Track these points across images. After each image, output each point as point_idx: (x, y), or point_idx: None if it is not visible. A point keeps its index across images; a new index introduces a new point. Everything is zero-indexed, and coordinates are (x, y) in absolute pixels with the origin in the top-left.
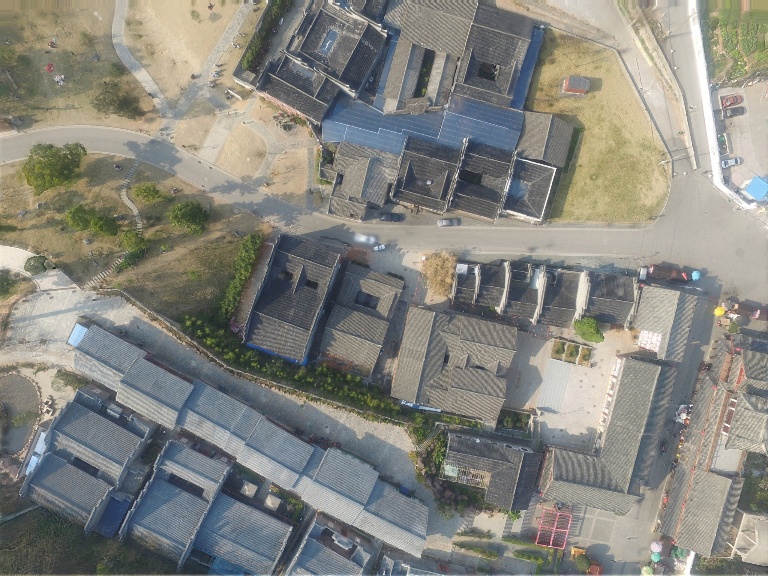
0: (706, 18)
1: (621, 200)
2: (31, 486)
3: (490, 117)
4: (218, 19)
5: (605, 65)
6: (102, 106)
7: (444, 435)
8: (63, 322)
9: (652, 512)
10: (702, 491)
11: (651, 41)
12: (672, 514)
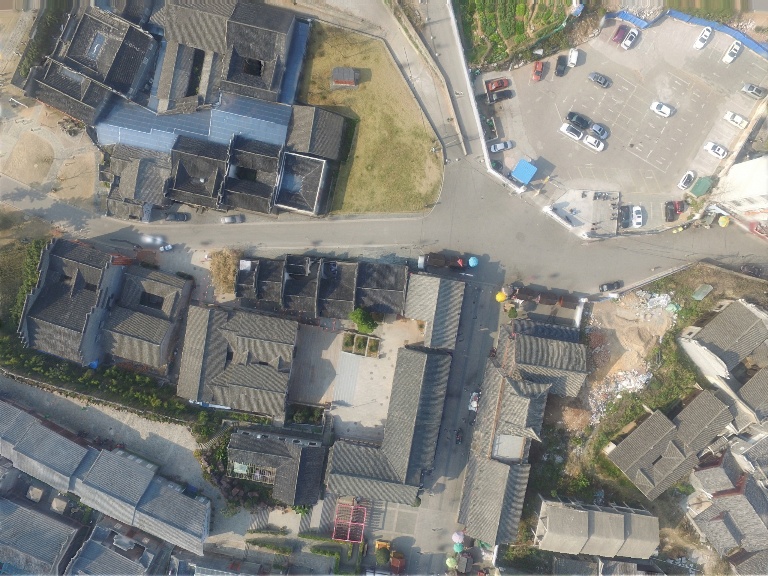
0: (464, 3)
1: (396, 189)
2: None
3: (257, 112)
4: (1, 29)
5: (373, 55)
6: None
7: (231, 432)
8: None
9: (455, 502)
10: (486, 479)
11: (410, 29)
12: (467, 503)
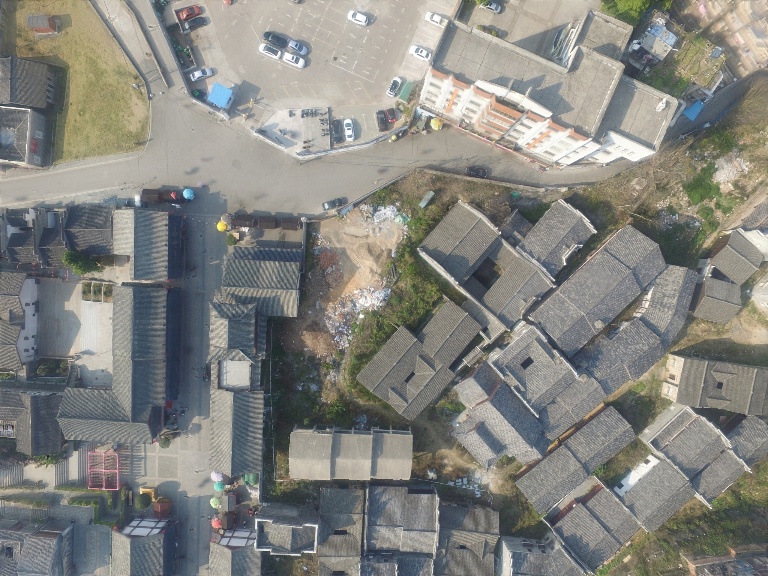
0: None
1: (108, 131)
2: None
3: None
4: None
5: (70, 0)
6: None
7: None
8: None
9: None
10: (219, 410)
11: None
12: None
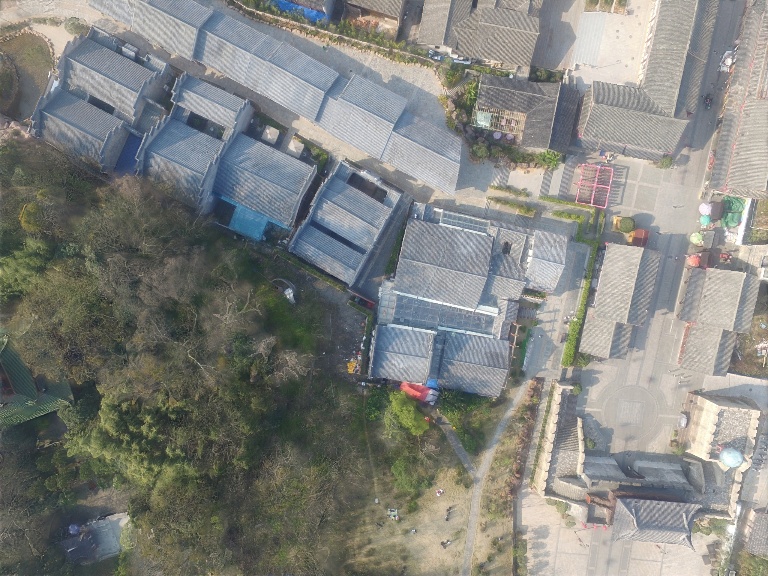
0: None
1: None
2: (43, 117)
3: None
4: None
5: None
6: None
7: None
8: None
9: (698, 176)
10: (754, 122)
11: None
12: (721, 164)
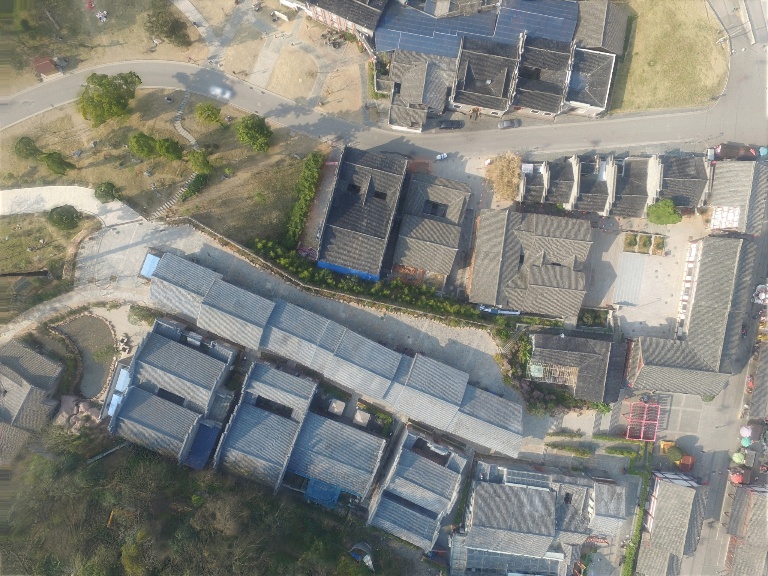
0: None
1: (681, 83)
2: (119, 420)
3: (545, 9)
4: None
5: None
6: (155, 28)
7: (526, 336)
8: (132, 257)
9: (737, 398)
10: None
11: None
12: (760, 395)
